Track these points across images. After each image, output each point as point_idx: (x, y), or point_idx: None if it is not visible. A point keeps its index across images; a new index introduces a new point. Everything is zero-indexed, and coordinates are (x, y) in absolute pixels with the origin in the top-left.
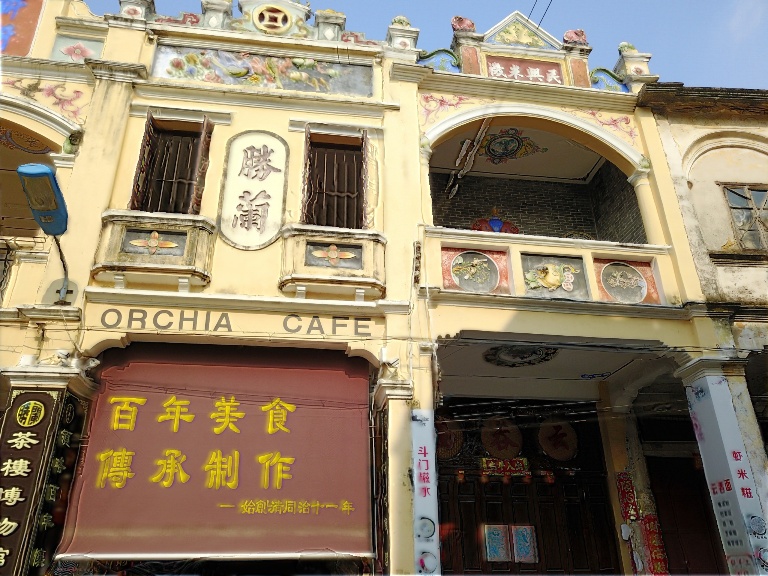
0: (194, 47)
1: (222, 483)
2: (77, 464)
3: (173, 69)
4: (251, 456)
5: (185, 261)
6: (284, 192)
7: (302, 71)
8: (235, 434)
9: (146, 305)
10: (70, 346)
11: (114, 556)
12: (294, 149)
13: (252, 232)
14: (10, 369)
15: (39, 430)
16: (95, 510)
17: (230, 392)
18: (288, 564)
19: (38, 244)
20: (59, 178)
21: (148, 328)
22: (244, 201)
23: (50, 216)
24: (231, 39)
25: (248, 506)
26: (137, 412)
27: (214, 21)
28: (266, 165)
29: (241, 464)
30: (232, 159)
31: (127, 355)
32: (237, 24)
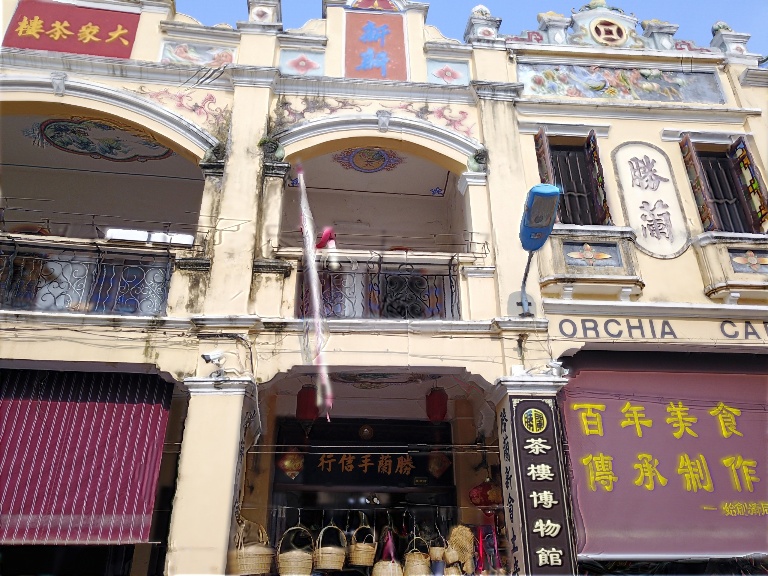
0: (548, 64)
1: (698, 486)
2: (567, 468)
3: (536, 86)
4: (715, 460)
5: (627, 271)
6: (679, 201)
7: (652, 81)
8: (694, 438)
9: (595, 315)
10: (546, 356)
11: (618, 557)
12: (673, 158)
13: (664, 241)
14: (509, 379)
15: (548, 436)
16: (595, 512)
17: (677, 397)
18: (705, 566)
19: (479, 259)
20: (474, 196)
21: (603, 337)
22: (646, 211)
23: (540, 233)
24: (583, 54)
25: (729, 508)
26: (601, 418)
27: (560, 37)
28: (653, 175)
29: (710, 467)
30: (621, 171)
31: (576, 363)
32: (578, 39)
